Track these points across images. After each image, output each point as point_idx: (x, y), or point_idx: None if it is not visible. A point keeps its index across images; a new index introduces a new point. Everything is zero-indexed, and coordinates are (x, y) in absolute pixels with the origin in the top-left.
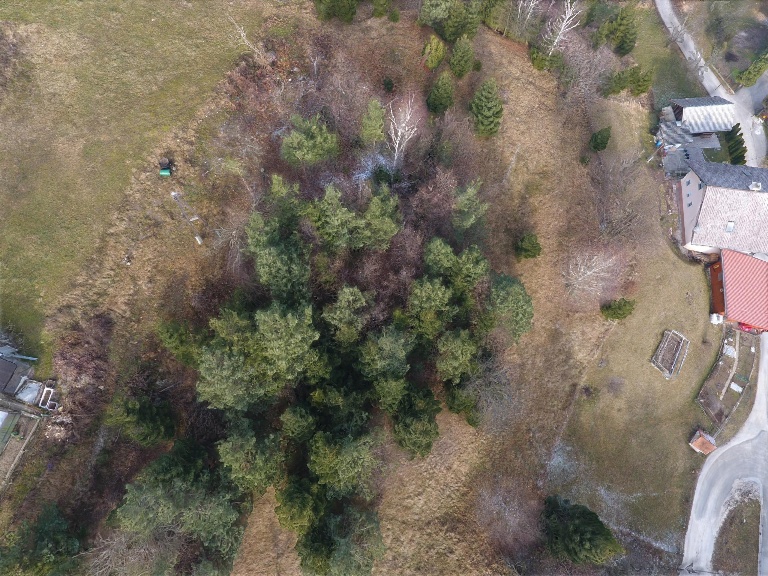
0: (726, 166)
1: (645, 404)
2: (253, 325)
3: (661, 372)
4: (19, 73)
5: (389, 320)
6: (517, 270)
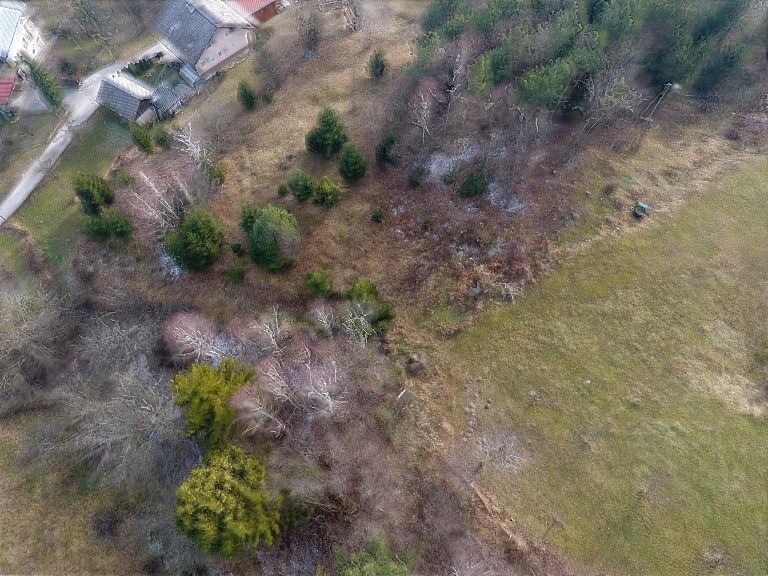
0: (174, 46)
1: (368, 2)
2: (643, 6)
3: (346, 3)
4: (767, 364)
5: (539, 7)
6: (387, 74)
